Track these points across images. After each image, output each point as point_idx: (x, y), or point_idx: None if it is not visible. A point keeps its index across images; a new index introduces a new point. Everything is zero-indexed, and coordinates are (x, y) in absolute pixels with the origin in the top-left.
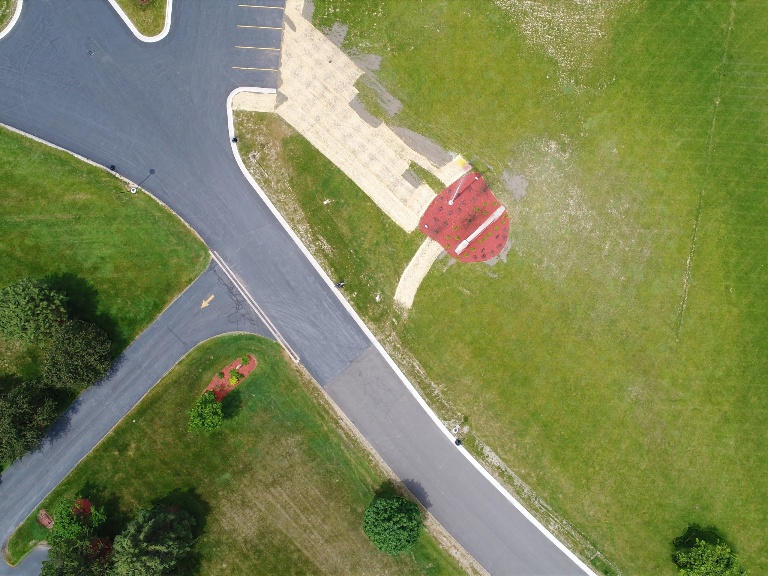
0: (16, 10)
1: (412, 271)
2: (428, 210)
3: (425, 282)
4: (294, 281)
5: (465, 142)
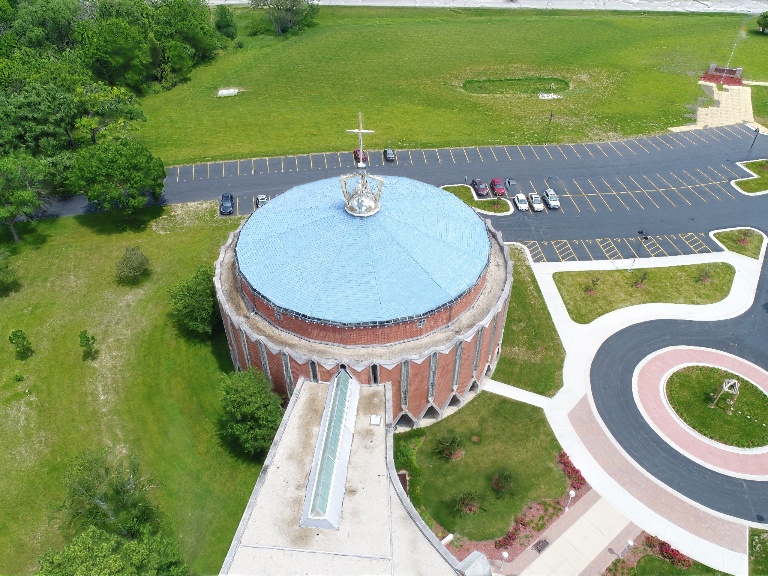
0: None
1: None
2: None
3: None
4: None
5: None
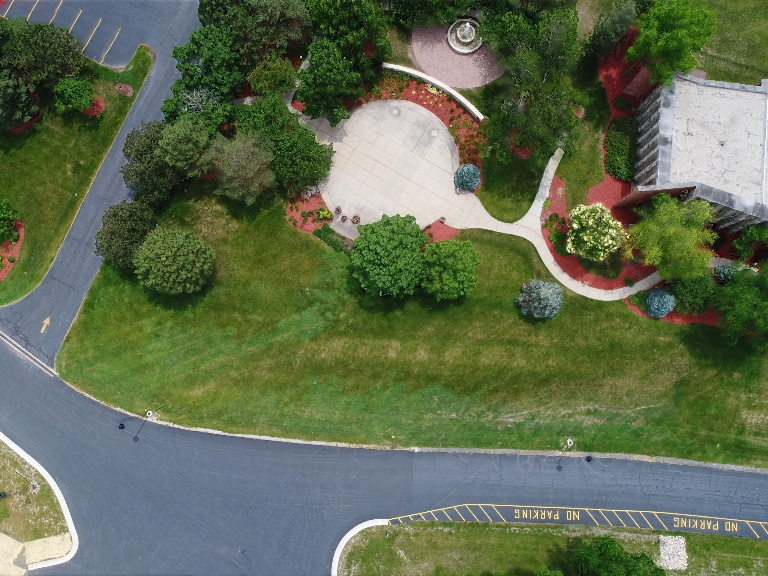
0: None
1: None
2: None
3: None
4: None
5: None
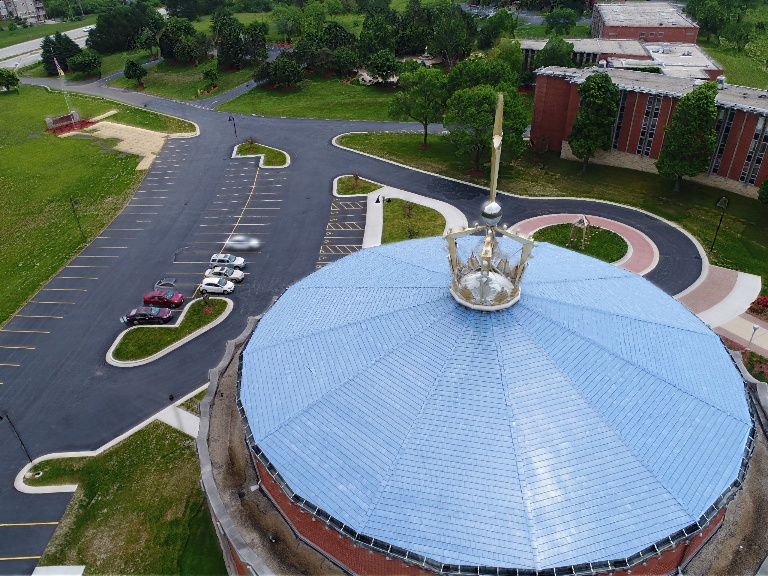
0: None
1: None
2: None
3: None
4: None
5: None
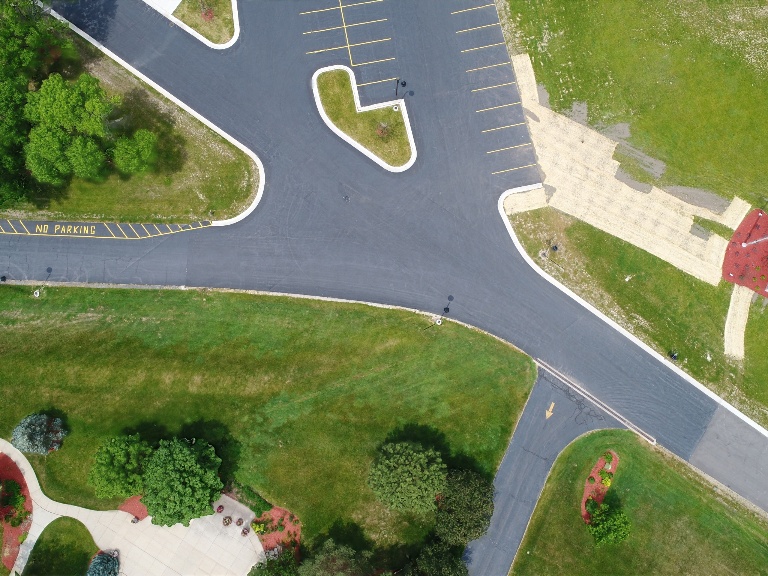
0: (260, 177)
1: (733, 322)
2: (726, 258)
3: (748, 329)
4: (624, 365)
5: (736, 183)
